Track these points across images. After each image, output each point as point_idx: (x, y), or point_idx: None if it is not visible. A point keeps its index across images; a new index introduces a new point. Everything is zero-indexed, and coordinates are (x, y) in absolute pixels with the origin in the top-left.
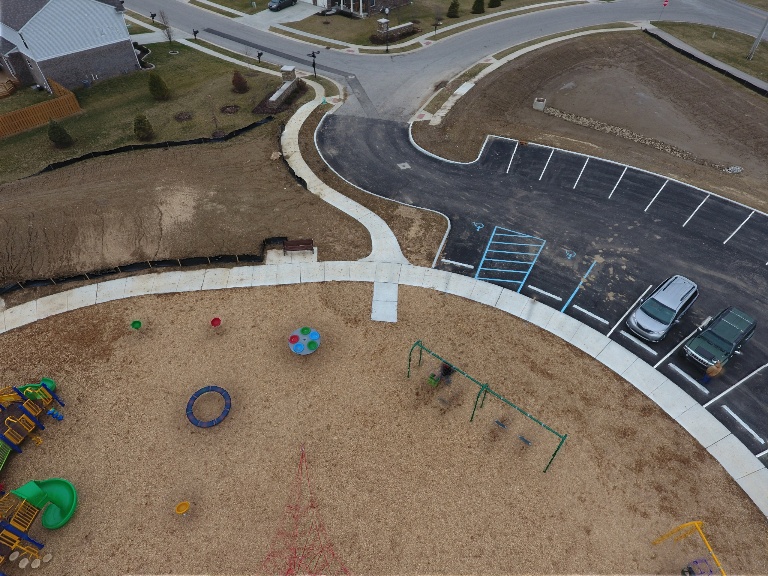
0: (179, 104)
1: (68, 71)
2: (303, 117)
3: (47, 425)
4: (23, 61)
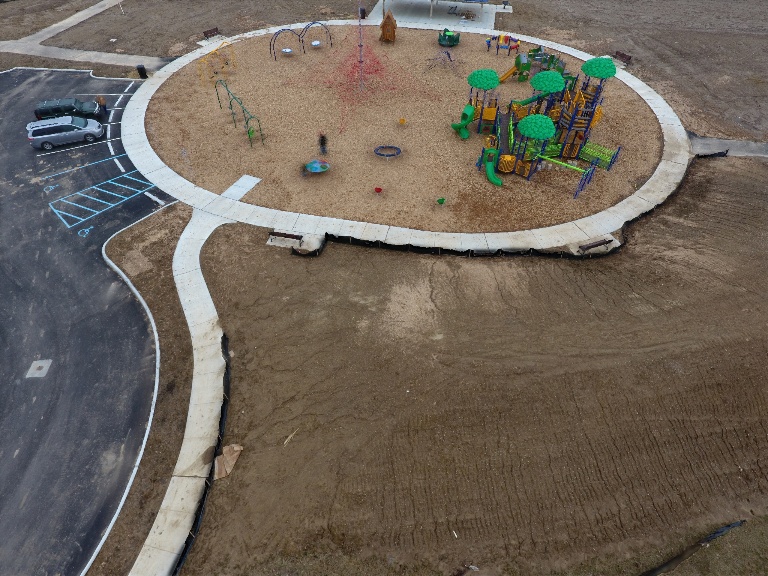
0: None
1: None
2: None
3: None
4: None
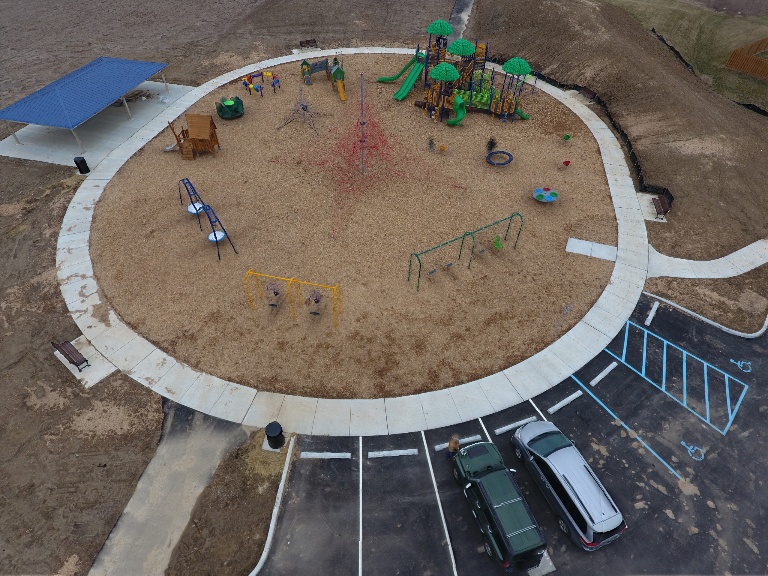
0: None
1: None
2: None
3: (501, 120)
4: None
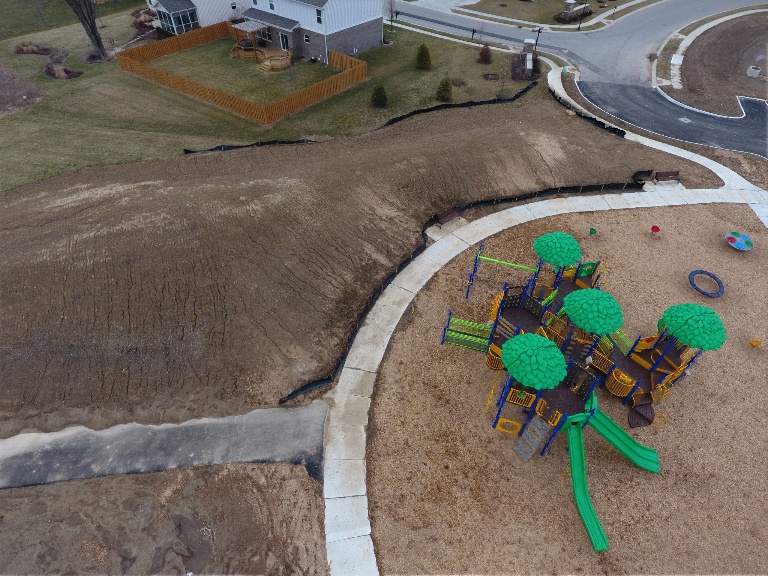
0: (443, 73)
1: (341, 44)
2: (558, 83)
3: None
4: (299, 36)
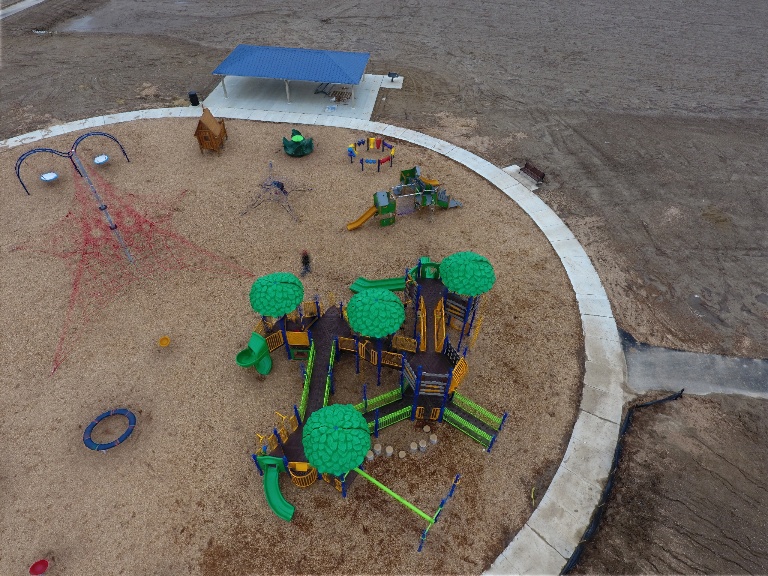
0: None
1: None
2: None
3: None
4: None
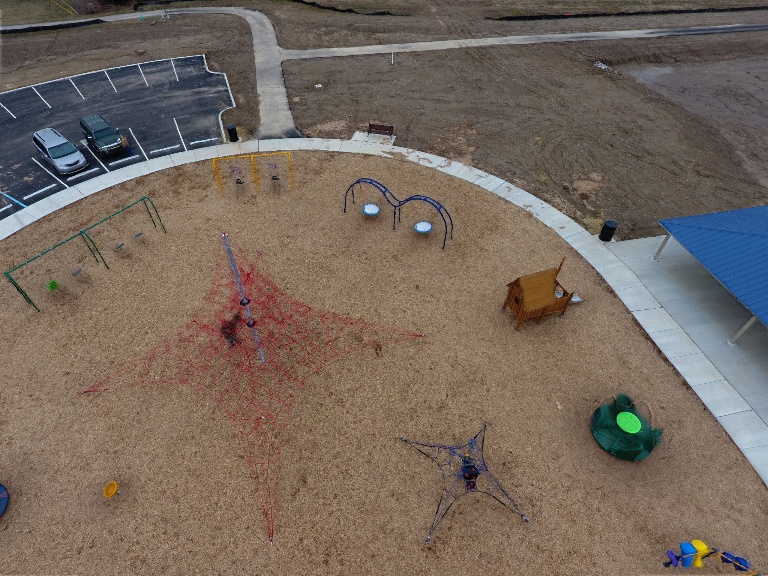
0: None
1: None
2: None
3: None
4: None
